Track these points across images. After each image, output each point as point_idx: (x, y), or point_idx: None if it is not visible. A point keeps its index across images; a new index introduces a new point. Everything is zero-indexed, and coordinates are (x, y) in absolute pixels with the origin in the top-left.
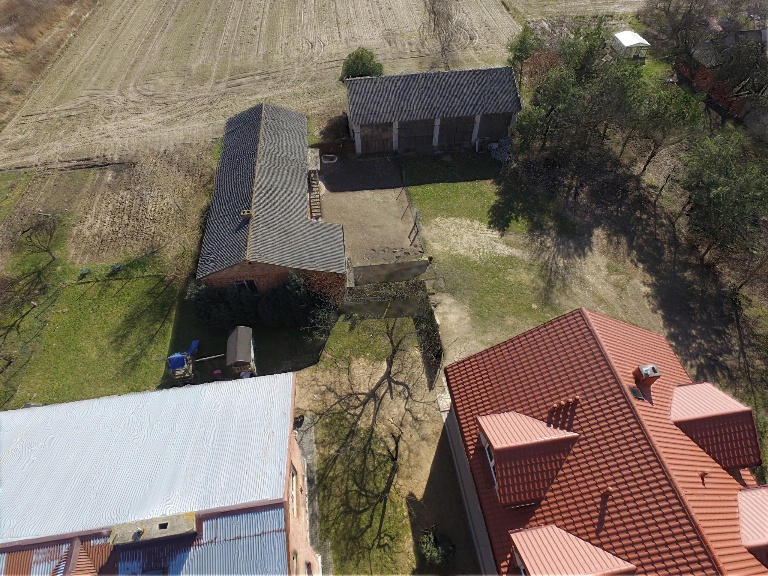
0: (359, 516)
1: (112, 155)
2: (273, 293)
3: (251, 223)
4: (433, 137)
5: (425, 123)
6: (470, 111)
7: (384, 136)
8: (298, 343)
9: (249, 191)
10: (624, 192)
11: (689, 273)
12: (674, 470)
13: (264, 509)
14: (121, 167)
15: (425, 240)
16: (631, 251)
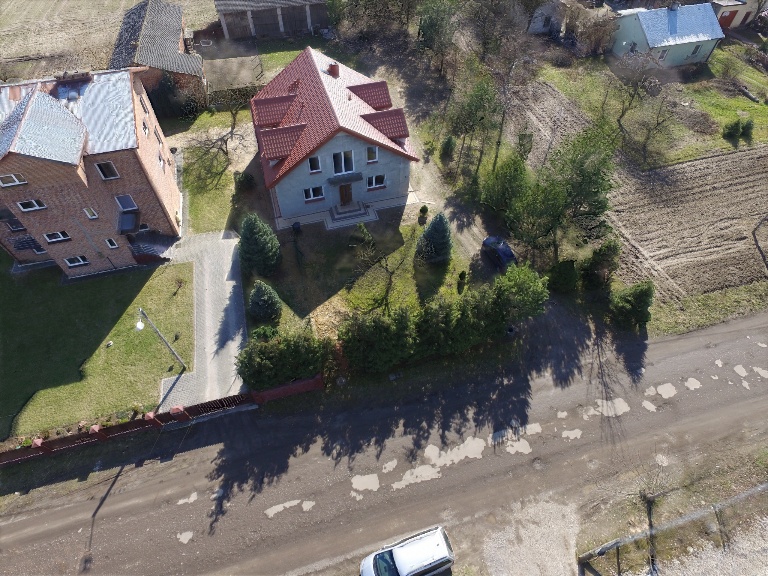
0: (206, 180)
1: (44, 53)
2: (156, 90)
3: (138, 49)
4: (279, 25)
5: (271, 13)
6: (300, 3)
7: (243, 24)
8: (176, 124)
9: (138, 37)
10: (405, 49)
11: (430, 81)
12: (329, 88)
13: (121, 71)
14: (52, 58)
15: (267, 78)
16: (399, 75)
